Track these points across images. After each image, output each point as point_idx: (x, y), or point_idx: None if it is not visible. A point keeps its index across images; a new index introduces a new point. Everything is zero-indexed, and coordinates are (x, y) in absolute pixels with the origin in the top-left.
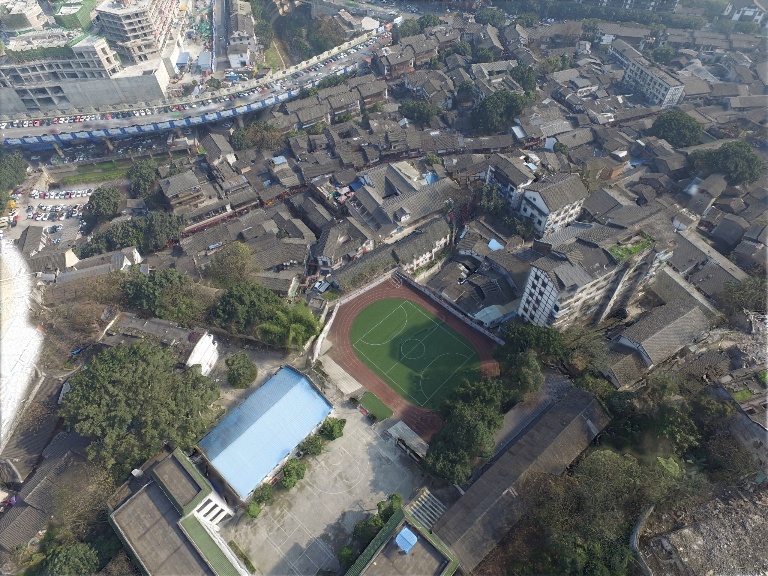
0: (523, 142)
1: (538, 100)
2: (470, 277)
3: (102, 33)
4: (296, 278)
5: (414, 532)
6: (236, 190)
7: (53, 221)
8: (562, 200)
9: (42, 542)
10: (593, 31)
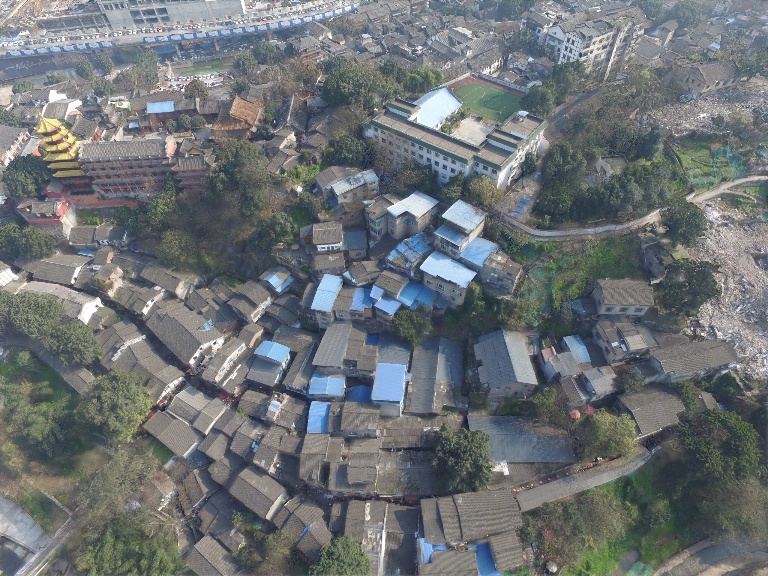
0: None
1: (544, 3)
2: (519, 75)
3: None
4: None
5: None
6: (339, 54)
7: None
8: None
9: None
10: None
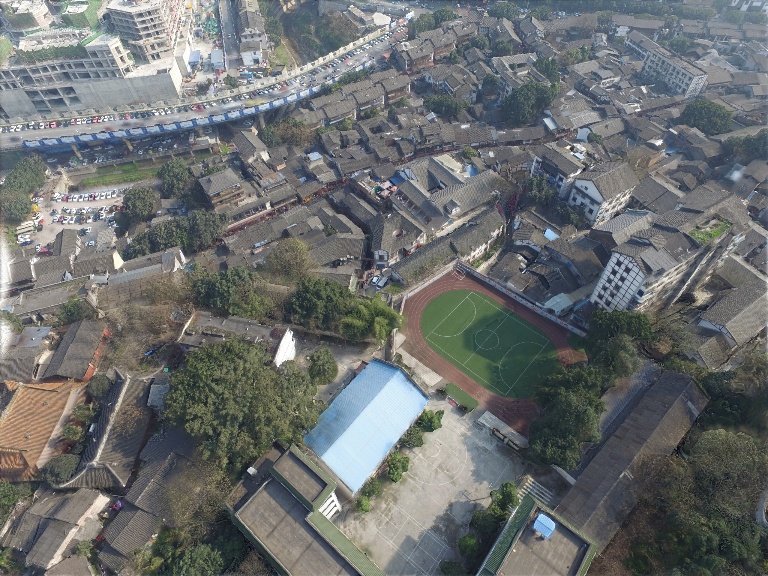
0: (554, 133)
1: (562, 92)
2: (531, 267)
3: (109, 32)
4: (354, 273)
5: None
6: (274, 187)
7: (80, 224)
8: (615, 188)
9: (154, 546)
10: (607, 23)
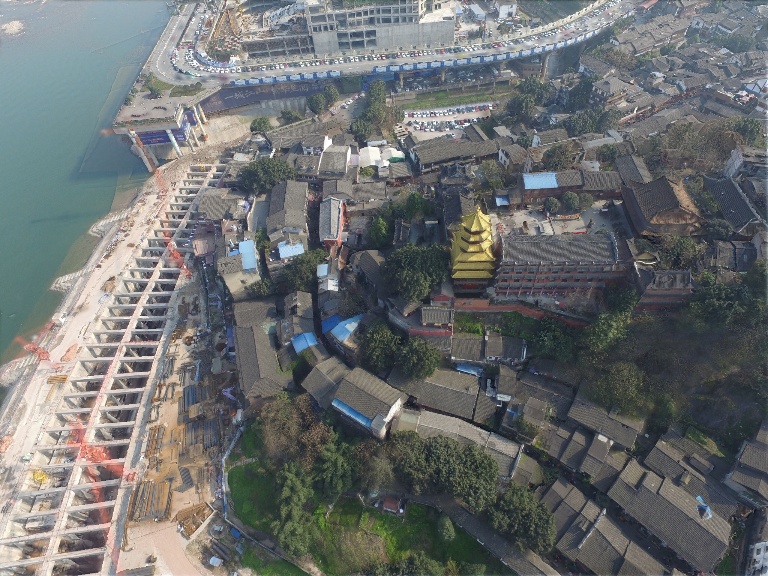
0: None
1: None
2: None
3: None
4: None
5: None
6: (633, 97)
7: (441, 131)
8: None
9: None
10: None
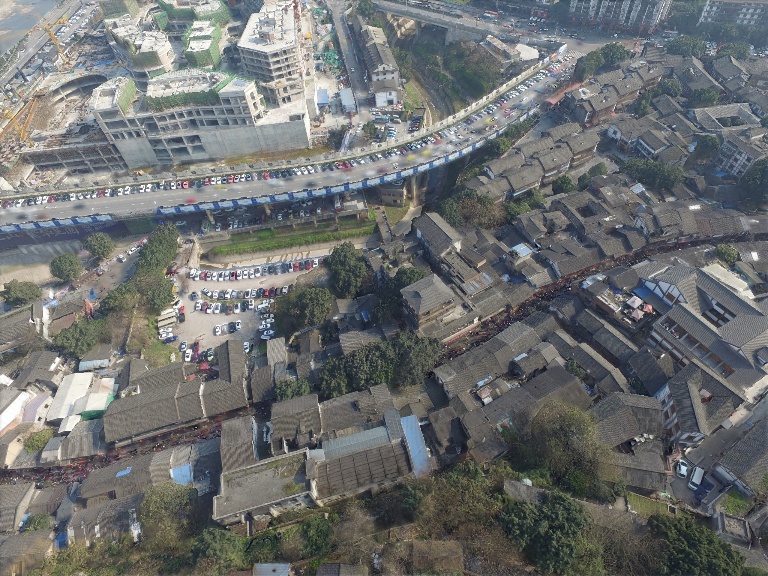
0: None
1: None
2: None
3: (227, 67)
4: None
5: None
6: (478, 293)
7: (227, 315)
8: None
9: None
10: None
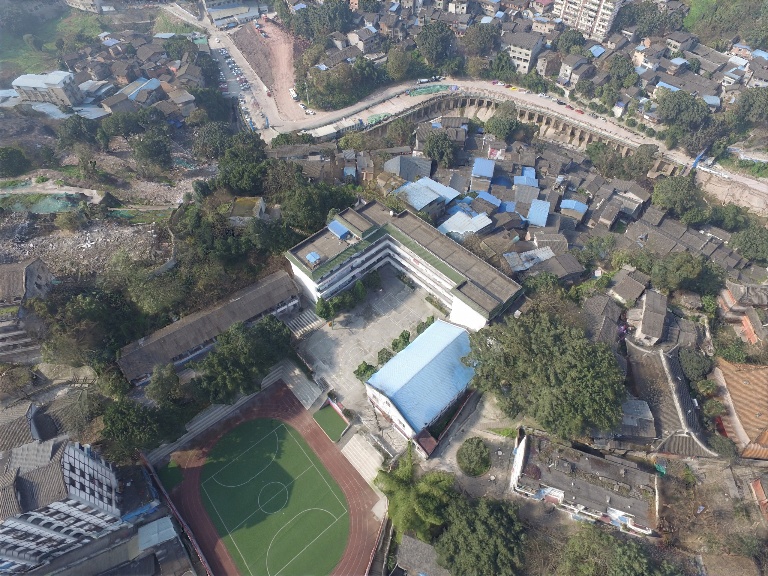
0: None
1: None
2: None
3: None
4: None
5: (308, 266)
6: None
7: None
8: None
9: None
10: None
